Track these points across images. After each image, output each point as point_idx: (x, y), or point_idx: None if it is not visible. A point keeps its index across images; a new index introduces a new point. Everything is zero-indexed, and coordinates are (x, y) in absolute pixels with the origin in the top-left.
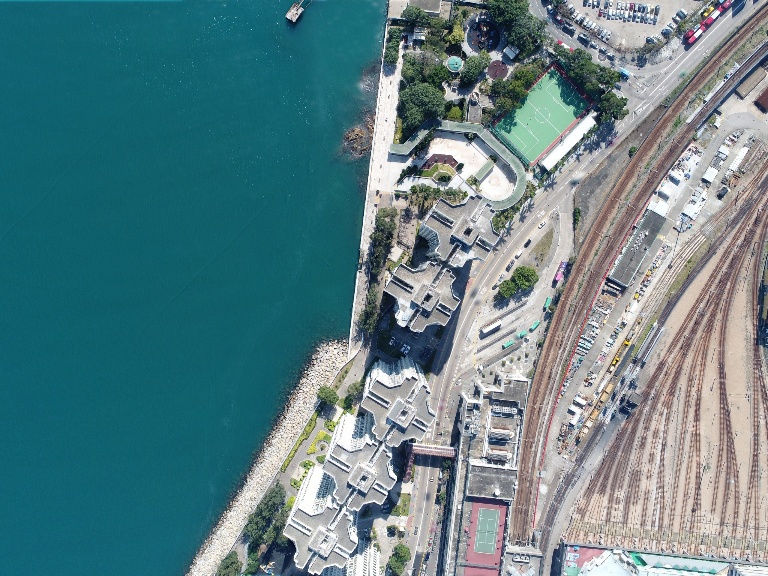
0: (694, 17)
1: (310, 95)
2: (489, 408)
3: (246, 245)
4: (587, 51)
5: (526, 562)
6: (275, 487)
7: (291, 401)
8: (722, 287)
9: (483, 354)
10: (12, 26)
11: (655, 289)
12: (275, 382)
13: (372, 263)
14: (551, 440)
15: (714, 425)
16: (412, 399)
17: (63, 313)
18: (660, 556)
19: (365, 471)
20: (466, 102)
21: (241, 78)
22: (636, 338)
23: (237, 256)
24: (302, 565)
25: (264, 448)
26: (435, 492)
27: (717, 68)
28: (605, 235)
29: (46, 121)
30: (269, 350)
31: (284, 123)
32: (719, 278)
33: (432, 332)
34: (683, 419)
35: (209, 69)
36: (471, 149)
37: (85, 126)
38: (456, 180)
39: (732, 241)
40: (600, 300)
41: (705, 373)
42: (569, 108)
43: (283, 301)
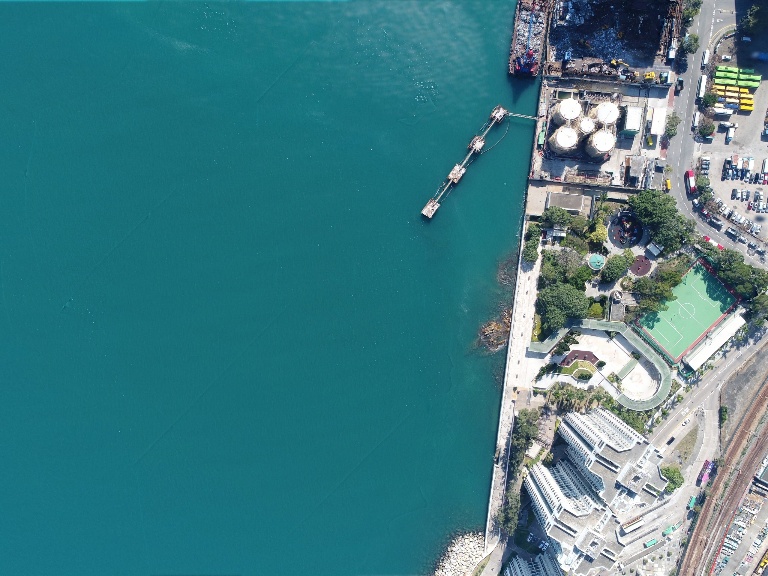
0: None
1: (445, 288)
2: None
3: (389, 453)
4: (735, 245)
5: None
6: None
7: None
8: None
9: None
10: (161, 242)
11: None
12: (409, 571)
13: (512, 465)
14: None
15: None
16: None
17: (209, 516)
18: None
19: None
20: None
21: (385, 290)
22: None
23: (380, 464)
24: None
25: None
26: None
27: None
28: (753, 434)
29: (193, 332)
30: (403, 539)
31: (427, 332)
32: None
33: None
34: None
35: (353, 281)
36: (612, 345)
37: (231, 338)
38: (596, 377)
39: None
40: (747, 500)
41: None
42: (715, 303)
43: None
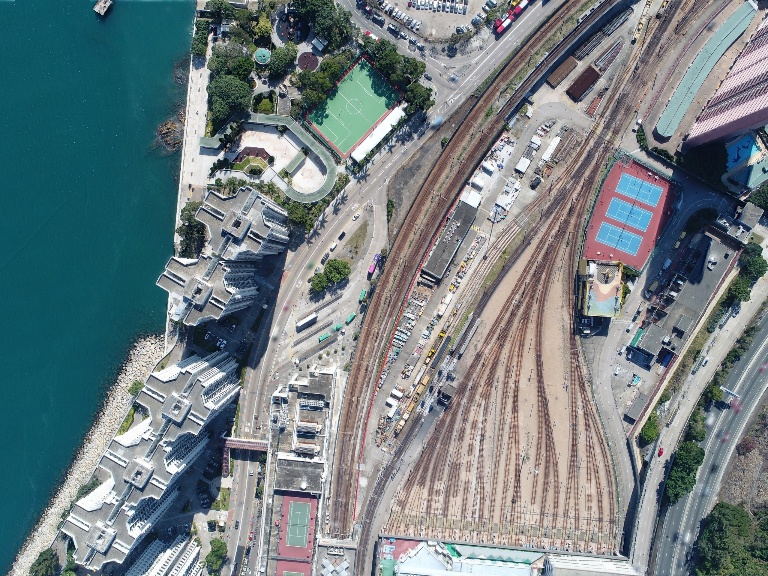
0: (503, 6)
1: (122, 89)
2: (297, 401)
3: (47, 240)
4: (397, 42)
5: (341, 555)
6: (90, 483)
7: (110, 397)
8: (537, 277)
9: (300, 347)
10: None
11: (471, 280)
12: (95, 378)
13: None
14: (370, 433)
15: (532, 416)
16: (188, 393)
17: None
18: (475, 547)
19: (139, 466)
20: (276, 94)
21: (36, 72)
22: (453, 330)
23: (38, 252)
24: (81, 561)
25: (84, 444)
26: (255, 486)
27: (528, 58)
28: (419, 227)
29: None
30: (88, 346)
31: (82, 117)
32: (534, 268)
33: (248, 326)
34: (501, 410)
35: (3, 63)
36: (283, 142)
37: None
38: (268, 173)
39: (546, 231)
40: (415, 292)
41: (522, 364)
42: (381, 99)
43: (101, 297)
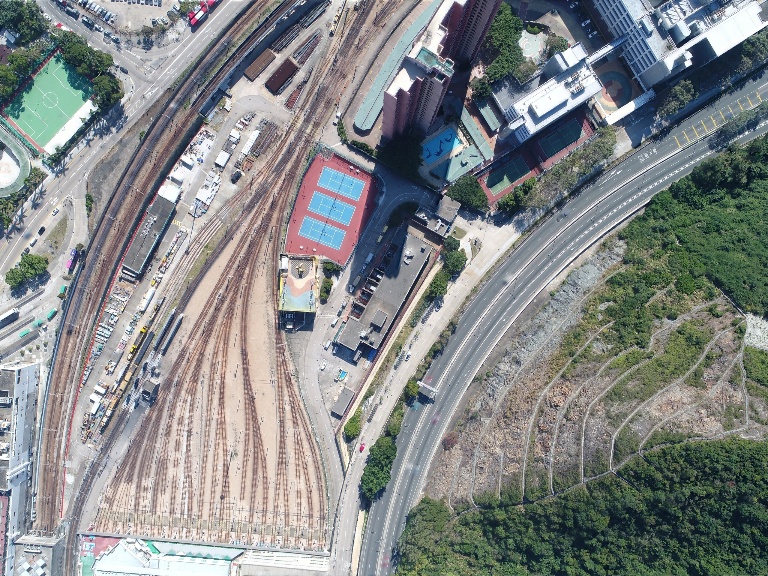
0: None
1: None
2: None
3: None
4: (92, 34)
5: (38, 552)
6: None
7: None
8: (241, 272)
9: (2, 344)
10: None
11: (173, 275)
12: None
13: None
14: (75, 429)
15: (239, 411)
16: None
17: None
18: (174, 544)
19: None
20: None
21: None
22: (156, 325)
23: None
24: None
25: None
26: None
27: (225, 50)
28: (118, 221)
29: None
30: None
31: None
32: (237, 263)
33: None
34: (207, 406)
35: None
36: None
37: None
38: None
39: (249, 226)
40: (117, 287)
41: (228, 359)
42: (77, 92)
43: None
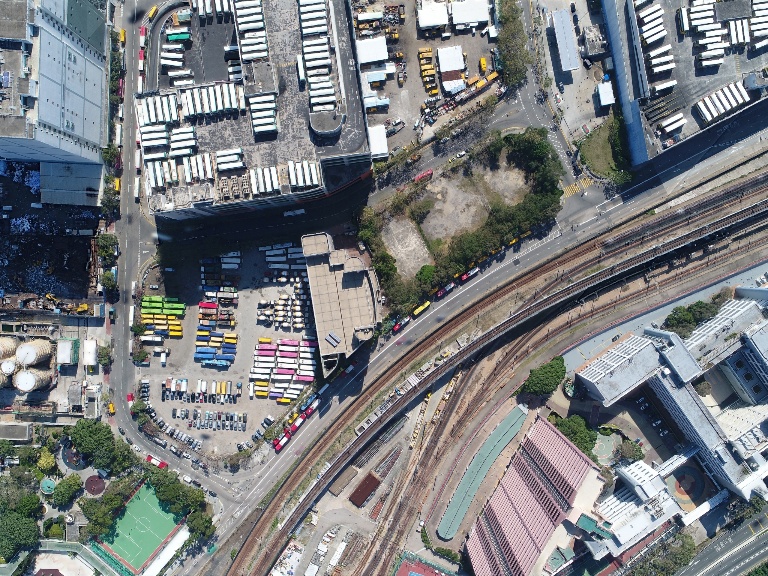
0: (281, 422)
1: None
2: None
3: None
4: (180, 461)
5: None
6: None
7: None
8: None
9: None
10: None
11: None
12: None
13: None
14: None
15: None
16: None
17: None
18: None
19: None
20: None
21: None
22: None
23: None
24: None
25: None
26: None
27: (309, 468)
28: None
29: None
30: None
31: None
32: None
33: None
34: None
35: None
36: (76, 562)
37: None
38: None
39: None
40: None
41: None
42: (169, 516)
43: None
